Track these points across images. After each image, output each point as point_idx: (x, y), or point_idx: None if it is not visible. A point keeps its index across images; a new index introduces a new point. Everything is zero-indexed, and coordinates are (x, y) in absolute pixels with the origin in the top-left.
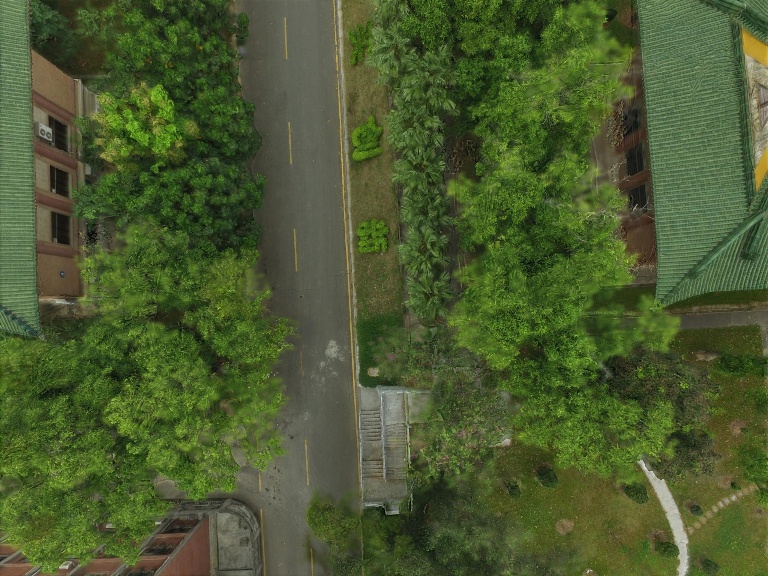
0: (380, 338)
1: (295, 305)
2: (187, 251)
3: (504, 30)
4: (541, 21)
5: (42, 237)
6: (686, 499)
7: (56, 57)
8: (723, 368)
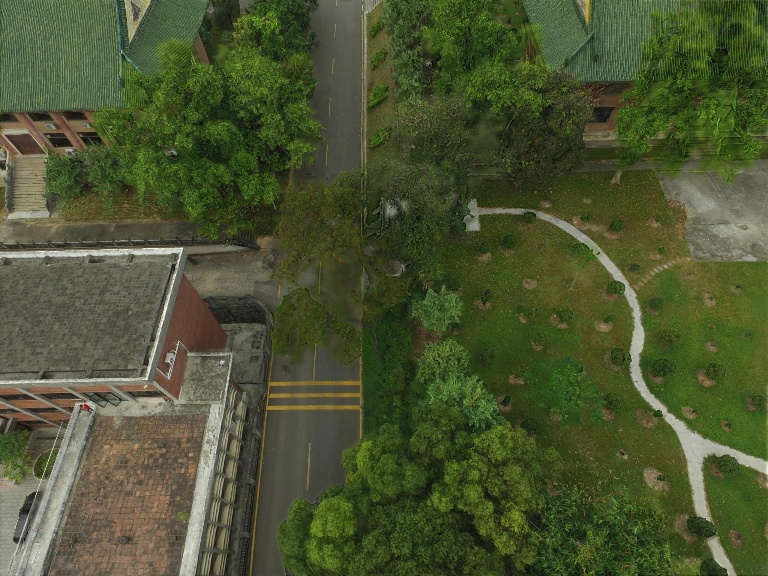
0: None
1: (323, 183)
2: None
3: None
4: None
5: None
6: (626, 266)
7: None
8: (620, 162)
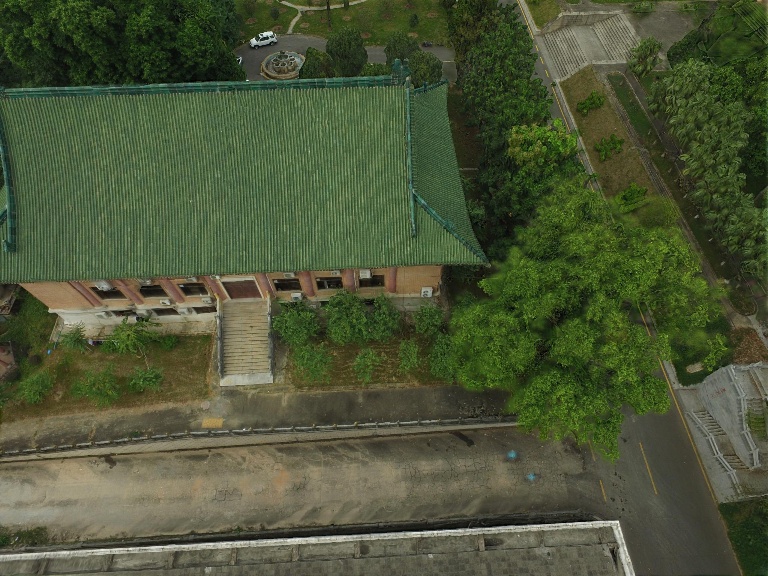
0: (697, 332)
1: None
2: None
3: None
4: None
5: None
6: None
7: None
8: None
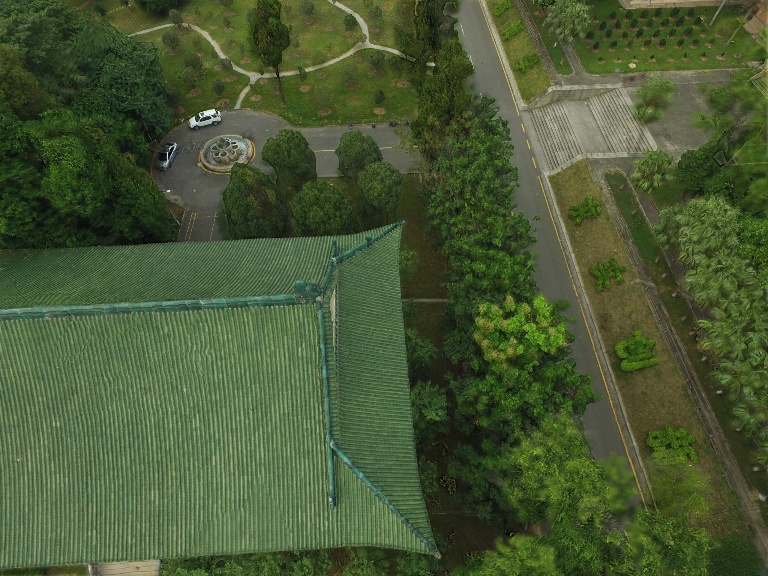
0: (725, 572)
1: None
2: None
3: None
4: None
5: None
6: None
7: None
8: None
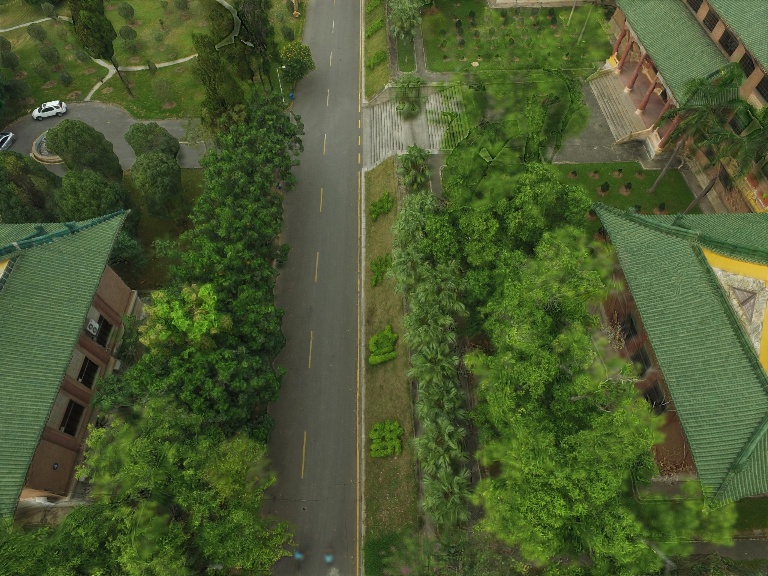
0: (392, 563)
1: (296, 519)
2: (196, 435)
3: (502, 246)
4: (532, 239)
5: (52, 423)
6: None
7: (121, 276)
8: None
